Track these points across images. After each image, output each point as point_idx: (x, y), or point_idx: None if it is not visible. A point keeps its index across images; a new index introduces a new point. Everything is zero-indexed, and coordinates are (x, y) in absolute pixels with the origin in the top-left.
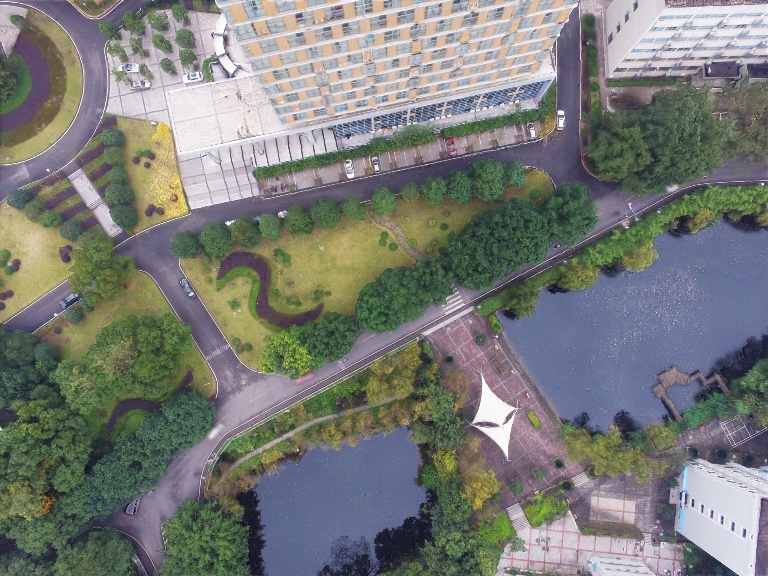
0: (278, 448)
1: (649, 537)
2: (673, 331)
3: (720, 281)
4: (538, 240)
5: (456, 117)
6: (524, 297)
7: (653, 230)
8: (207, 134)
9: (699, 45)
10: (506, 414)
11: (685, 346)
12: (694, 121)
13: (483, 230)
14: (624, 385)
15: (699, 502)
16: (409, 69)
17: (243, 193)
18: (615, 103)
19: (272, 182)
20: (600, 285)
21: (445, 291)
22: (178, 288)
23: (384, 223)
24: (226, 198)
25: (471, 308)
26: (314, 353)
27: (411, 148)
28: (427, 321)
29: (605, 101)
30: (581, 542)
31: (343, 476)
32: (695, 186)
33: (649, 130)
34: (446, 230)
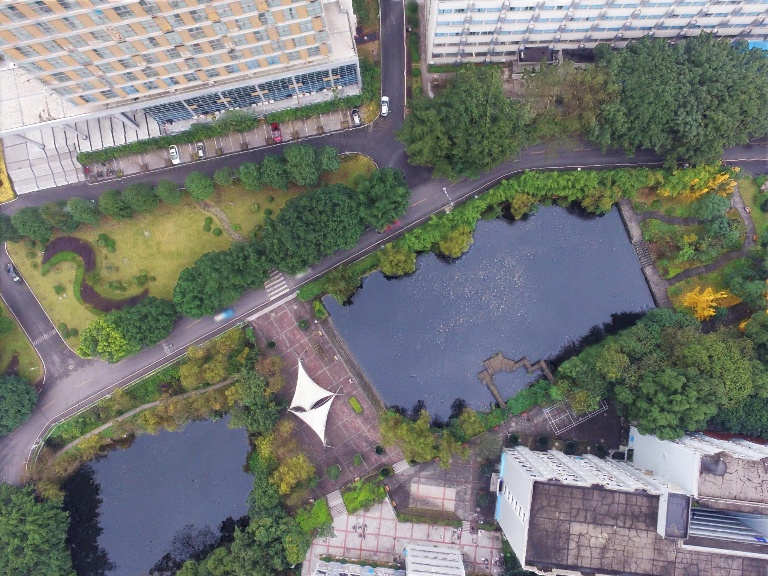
0: (105, 434)
1: (468, 525)
2: (500, 317)
3: (548, 267)
4: (345, 224)
5: (279, 103)
6: (333, 281)
7: (469, 215)
8: (9, 117)
9: (499, 29)
10: (318, 399)
11: (512, 333)
12: (486, 103)
13: (290, 213)
14: (450, 372)
15: (507, 488)
16: (176, 49)
17: (69, 178)
18: (436, 89)
19: (98, 167)
20: (427, 271)
21: (258, 275)
22: (4, 273)
23: (208, 208)
24: (52, 183)
25: (295, 293)
26: (127, 337)
27: (236, 134)
28: (252, 306)
29: (427, 87)
30: (398, 529)
31: (171, 462)
32: (518, 172)
33: (442, 112)
34: (270, 215)
